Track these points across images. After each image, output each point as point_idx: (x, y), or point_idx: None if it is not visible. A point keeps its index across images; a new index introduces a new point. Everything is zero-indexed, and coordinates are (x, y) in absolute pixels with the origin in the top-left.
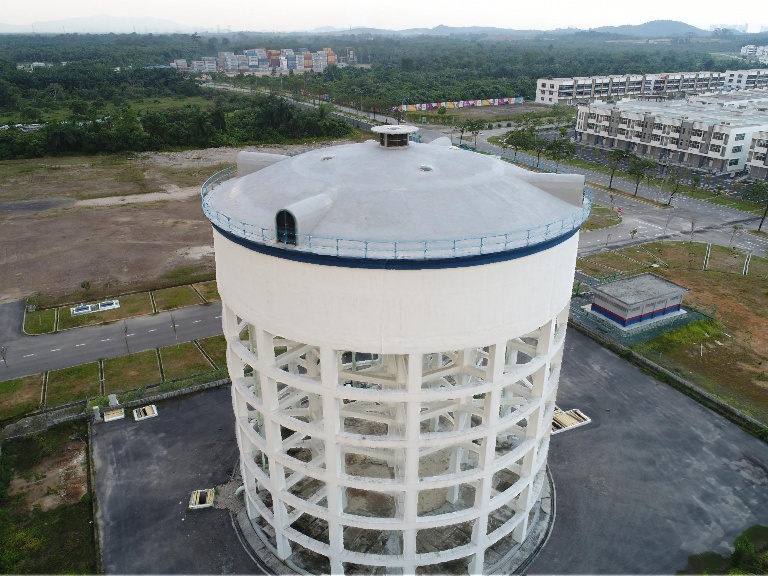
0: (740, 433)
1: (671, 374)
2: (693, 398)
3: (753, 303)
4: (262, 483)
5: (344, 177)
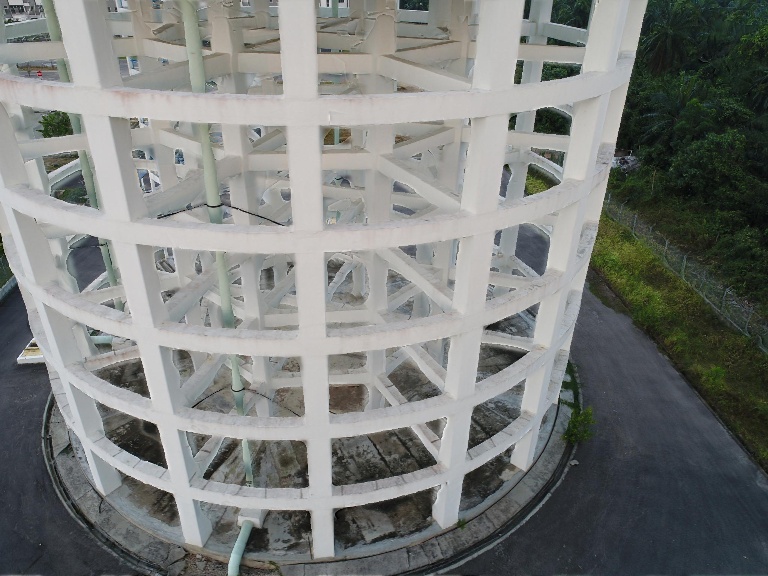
0: None
1: None
2: None
3: None
4: (427, 417)
5: None
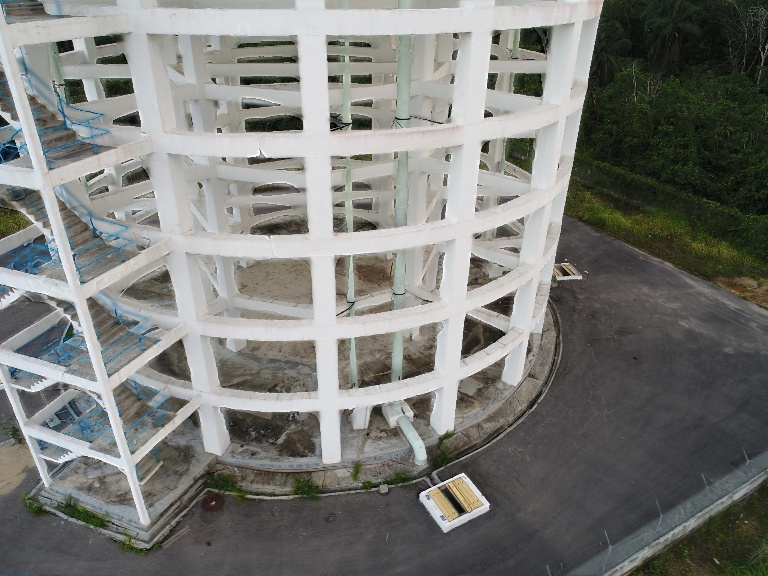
0: None
1: None
2: None
3: None
4: None
5: None
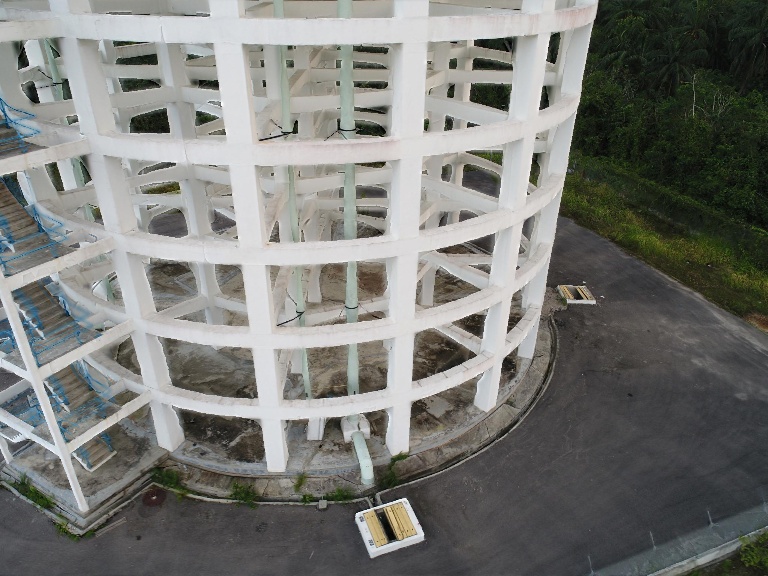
0: None
1: None
2: None
3: None
4: None
5: None
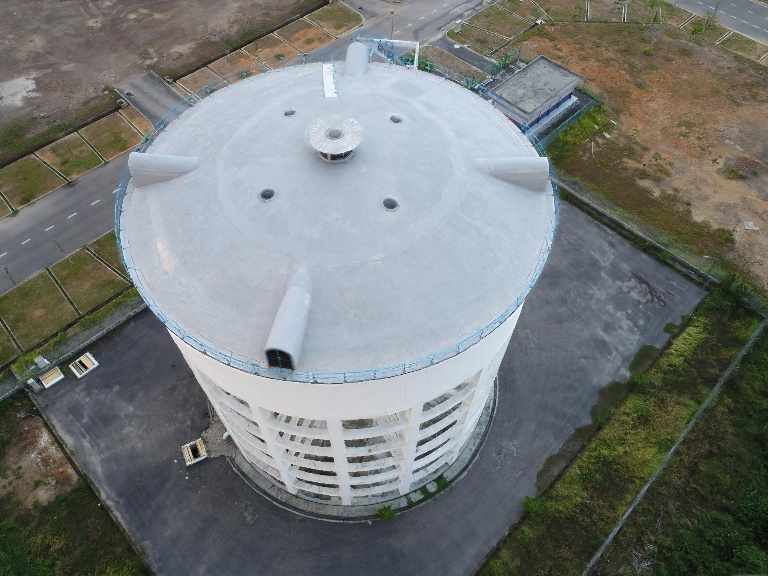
0: (629, 249)
1: (570, 191)
2: (590, 215)
3: (633, 69)
4: (266, 463)
5: (306, 243)
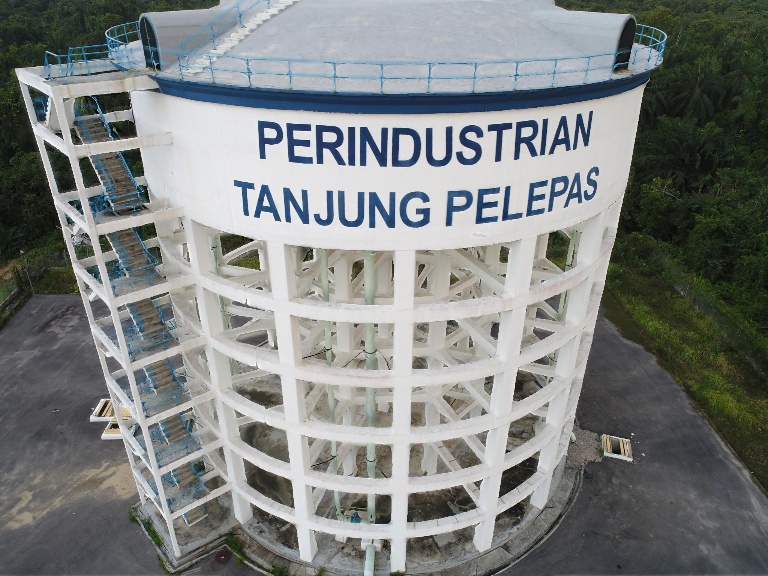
0: None
1: None
2: None
3: None
4: None
5: None
